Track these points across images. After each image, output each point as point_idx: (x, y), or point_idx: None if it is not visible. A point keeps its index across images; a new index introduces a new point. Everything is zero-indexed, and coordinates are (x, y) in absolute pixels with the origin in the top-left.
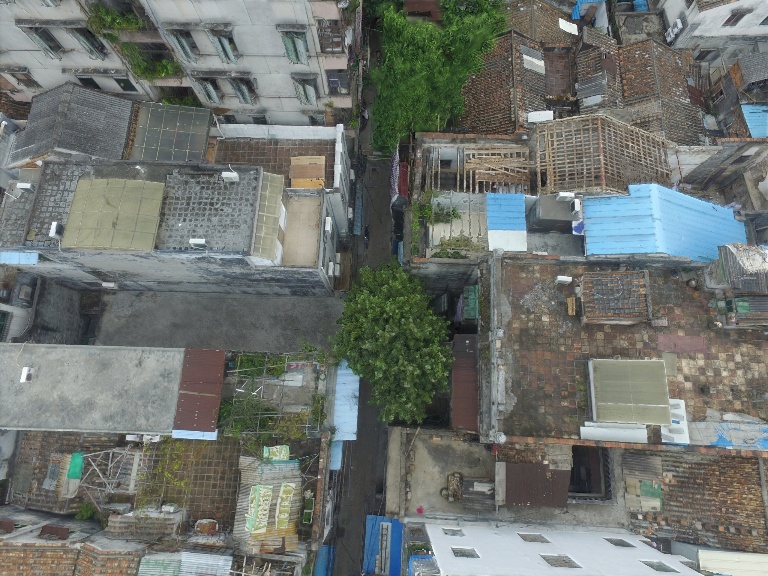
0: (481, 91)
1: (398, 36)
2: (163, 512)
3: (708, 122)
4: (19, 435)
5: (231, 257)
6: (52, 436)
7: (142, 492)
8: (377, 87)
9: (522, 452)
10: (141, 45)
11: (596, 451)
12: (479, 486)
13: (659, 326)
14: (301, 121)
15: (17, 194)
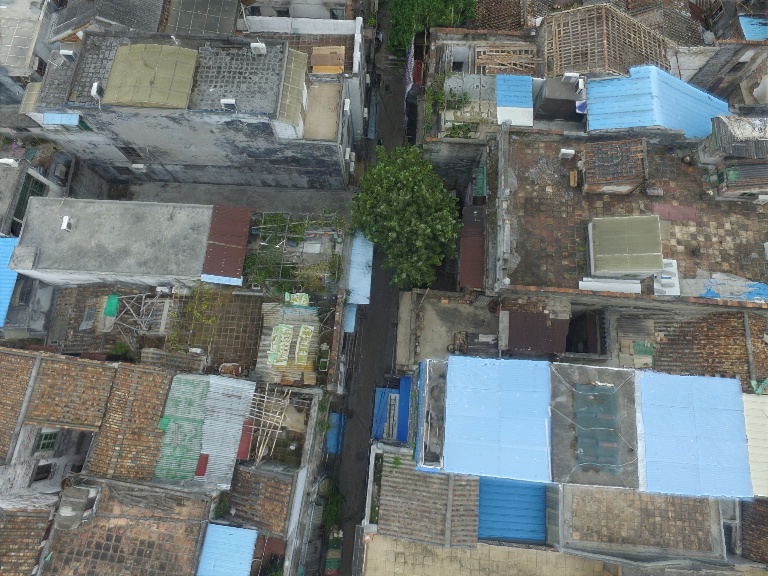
0: (492, 0)
1: None
2: (191, 352)
3: (708, 38)
4: (55, 294)
5: (258, 121)
6: (87, 290)
7: (173, 328)
8: (392, 6)
9: (524, 306)
10: None
11: (593, 317)
12: (484, 337)
13: (655, 196)
14: (322, 17)
15: (59, 63)
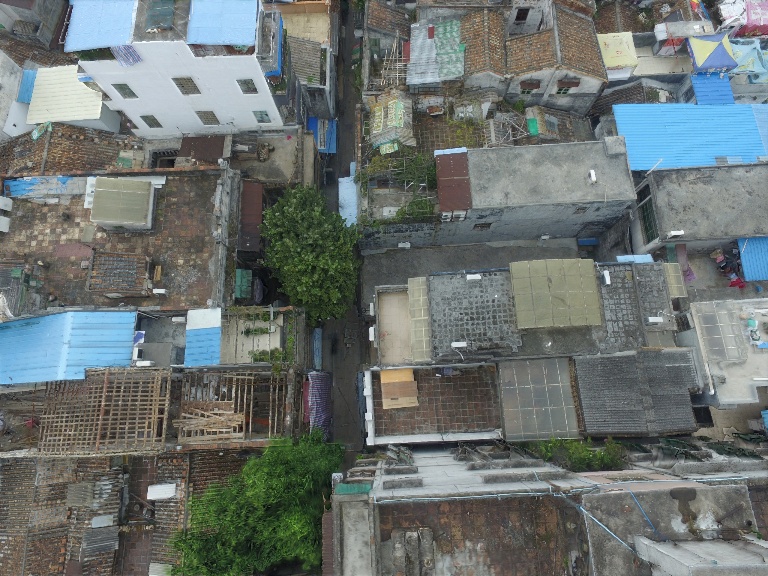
0: None
1: None
2: None
3: None
4: None
5: None
6: None
7: (479, 115)
8: None
9: None
10: None
11: None
12: (244, 148)
13: None
14: None
15: (663, 317)
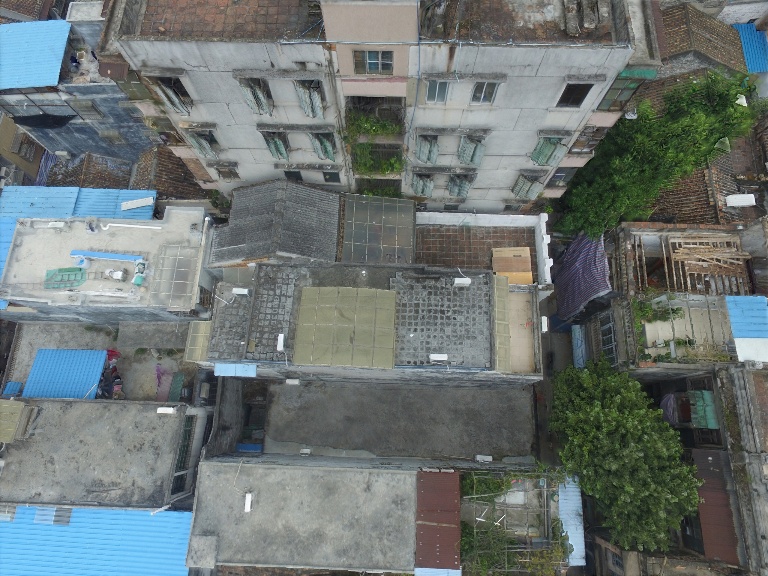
0: None
1: (637, 132)
2: None
3: None
4: None
5: (467, 371)
6: None
7: None
8: None
9: None
10: (376, 145)
11: None
12: None
13: None
14: (496, 208)
15: (228, 298)
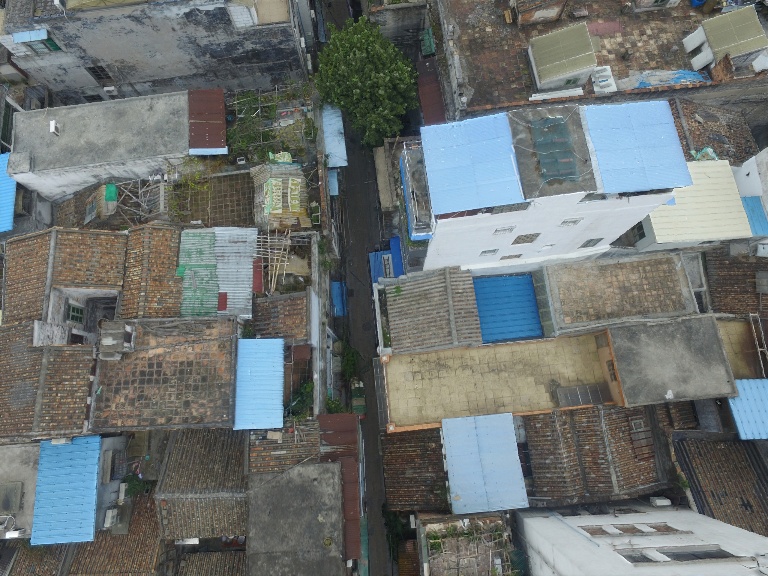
0: None
1: None
2: None
3: None
4: (53, 210)
5: (215, 7)
6: (84, 195)
7: (172, 199)
8: None
9: None
10: None
11: None
12: None
13: (582, 18)
14: None
15: None
